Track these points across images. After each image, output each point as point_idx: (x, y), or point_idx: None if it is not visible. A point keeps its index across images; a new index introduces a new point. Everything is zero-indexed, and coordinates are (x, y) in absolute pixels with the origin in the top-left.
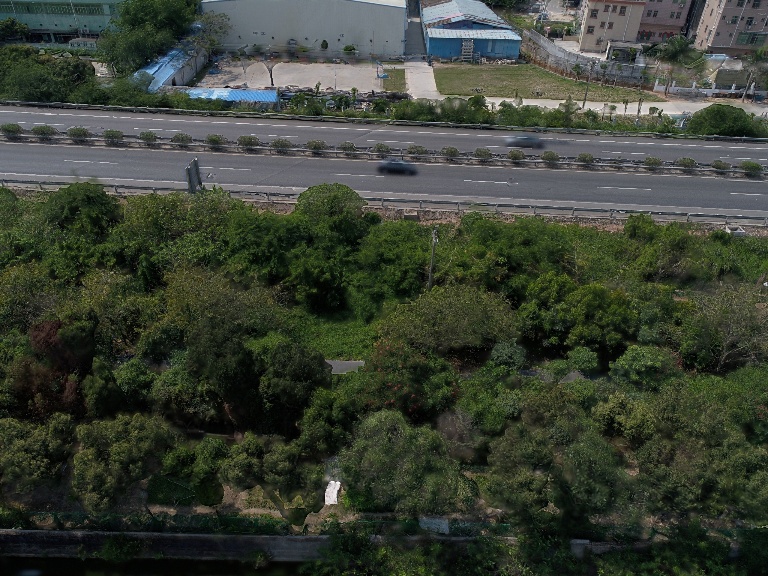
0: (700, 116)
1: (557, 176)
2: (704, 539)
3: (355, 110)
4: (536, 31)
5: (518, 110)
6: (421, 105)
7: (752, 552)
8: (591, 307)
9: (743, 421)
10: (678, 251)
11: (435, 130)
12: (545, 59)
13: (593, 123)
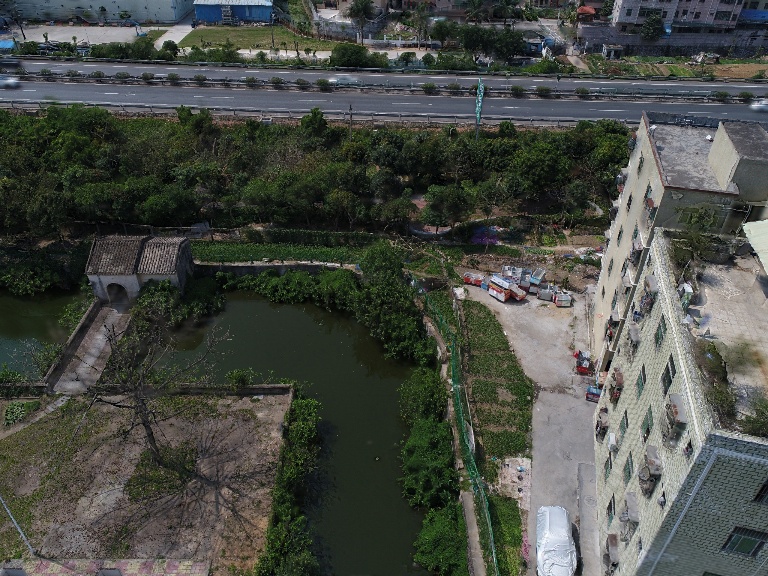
0: (334, 53)
1: (171, 90)
2: (49, 261)
3: (77, 55)
4: (311, 1)
5: (205, 53)
6: (113, 47)
7: (74, 266)
8: (69, 149)
9: (100, 199)
10: (198, 129)
11: (115, 64)
12: (288, 21)
13: (261, 62)
